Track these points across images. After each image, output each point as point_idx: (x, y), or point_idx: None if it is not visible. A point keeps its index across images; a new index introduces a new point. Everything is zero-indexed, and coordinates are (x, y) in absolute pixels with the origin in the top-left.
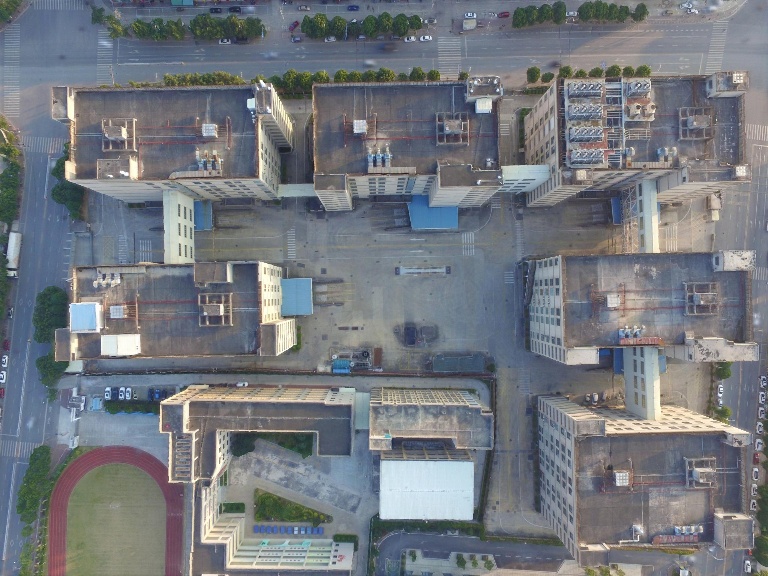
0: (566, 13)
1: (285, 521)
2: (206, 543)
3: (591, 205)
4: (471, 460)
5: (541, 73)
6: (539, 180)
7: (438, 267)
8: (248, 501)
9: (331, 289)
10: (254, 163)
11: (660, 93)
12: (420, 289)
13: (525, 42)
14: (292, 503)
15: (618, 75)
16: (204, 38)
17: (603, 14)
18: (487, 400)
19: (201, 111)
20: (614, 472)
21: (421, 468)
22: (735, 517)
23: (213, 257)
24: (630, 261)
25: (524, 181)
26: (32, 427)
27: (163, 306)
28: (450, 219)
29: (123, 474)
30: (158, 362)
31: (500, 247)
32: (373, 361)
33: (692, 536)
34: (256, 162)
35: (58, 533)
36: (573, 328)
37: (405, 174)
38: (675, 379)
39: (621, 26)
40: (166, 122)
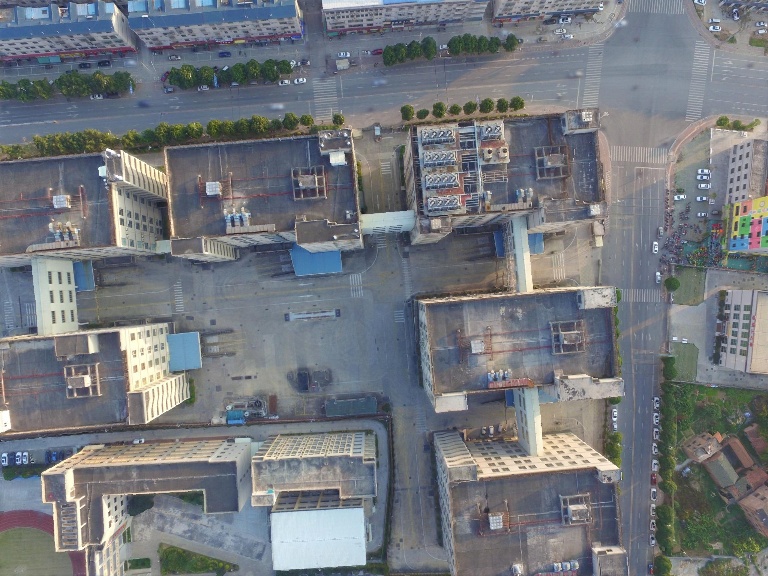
0: (440, 46)
1: (191, 573)
2: None
3: (477, 238)
4: (361, 506)
5: (417, 109)
6: (407, 225)
7: (327, 311)
8: (153, 556)
9: (222, 340)
10: None
11: (516, 133)
12: (311, 334)
13: (401, 78)
14: (197, 555)
15: (491, 108)
16: (73, 96)
17: (472, 47)
18: (385, 440)
19: (54, 181)
20: (488, 516)
21: (311, 518)
22: (610, 551)
23: (98, 317)
24: (495, 304)
25: (393, 227)
26: None
27: (30, 380)
28: (333, 263)
29: (27, 538)
30: None
31: (388, 286)
32: (268, 409)
33: (571, 572)
34: (111, 231)
35: None
36: (442, 375)
37: (264, 232)
38: (570, 406)
39: (496, 56)
40: (19, 195)
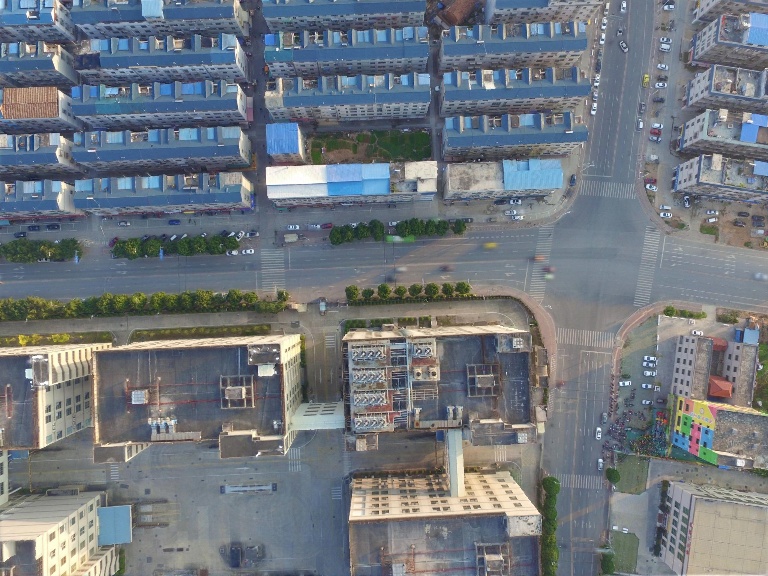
0: (389, 223)
1: None
2: None
3: None
4: None
5: None
6: None
7: (264, 484)
8: None
9: (156, 509)
10: (36, 430)
11: (449, 348)
12: (246, 507)
13: (349, 252)
14: None
15: (436, 293)
16: None
17: (419, 233)
18: None
19: None
20: None
21: None
22: None
23: (30, 485)
24: (421, 521)
25: None
26: None
27: None
28: None
29: None
30: None
31: (327, 462)
32: None
33: None
34: (34, 435)
35: None
36: None
37: None
38: None
39: (446, 234)
40: None
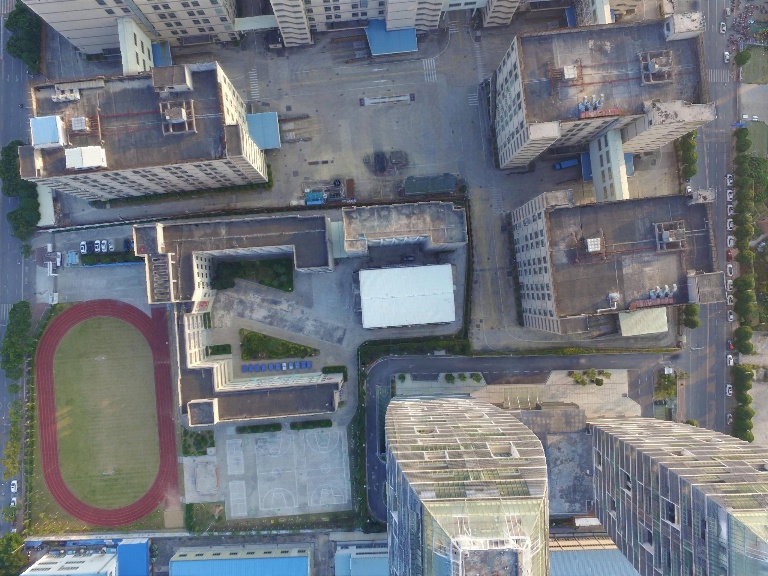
0: None
1: (273, 358)
2: (193, 369)
3: (547, 22)
4: (448, 263)
5: None
6: None
7: (402, 95)
8: (234, 342)
9: (298, 126)
10: None
11: None
12: (386, 118)
13: None
14: (278, 340)
15: None
16: None
17: None
18: None
19: None
20: None
21: (400, 274)
22: None
23: None
24: (584, 37)
25: None
26: (10, 289)
27: (125, 119)
28: (409, 42)
29: (106, 327)
30: (131, 212)
31: (461, 70)
32: (346, 192)
33: (667, 298)
34: None
35: (46, 392)
36: (534, 107)
37: None
38: (644, 185)
39: None
40: None
